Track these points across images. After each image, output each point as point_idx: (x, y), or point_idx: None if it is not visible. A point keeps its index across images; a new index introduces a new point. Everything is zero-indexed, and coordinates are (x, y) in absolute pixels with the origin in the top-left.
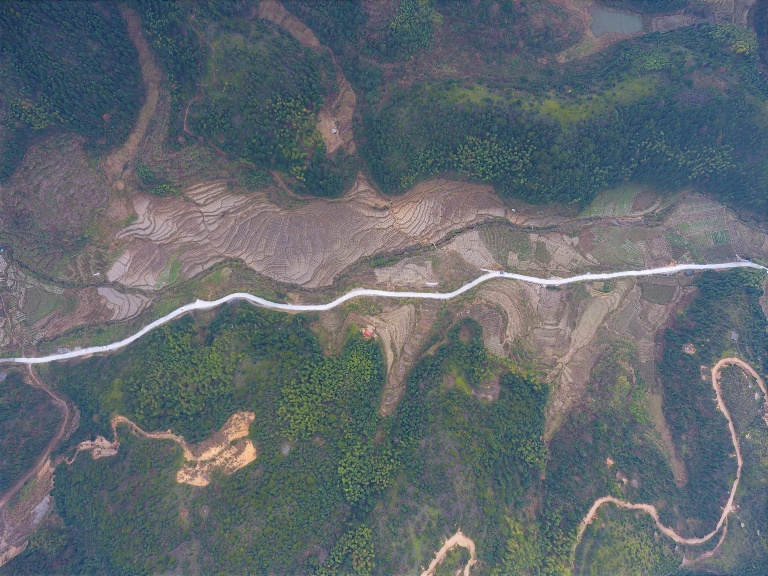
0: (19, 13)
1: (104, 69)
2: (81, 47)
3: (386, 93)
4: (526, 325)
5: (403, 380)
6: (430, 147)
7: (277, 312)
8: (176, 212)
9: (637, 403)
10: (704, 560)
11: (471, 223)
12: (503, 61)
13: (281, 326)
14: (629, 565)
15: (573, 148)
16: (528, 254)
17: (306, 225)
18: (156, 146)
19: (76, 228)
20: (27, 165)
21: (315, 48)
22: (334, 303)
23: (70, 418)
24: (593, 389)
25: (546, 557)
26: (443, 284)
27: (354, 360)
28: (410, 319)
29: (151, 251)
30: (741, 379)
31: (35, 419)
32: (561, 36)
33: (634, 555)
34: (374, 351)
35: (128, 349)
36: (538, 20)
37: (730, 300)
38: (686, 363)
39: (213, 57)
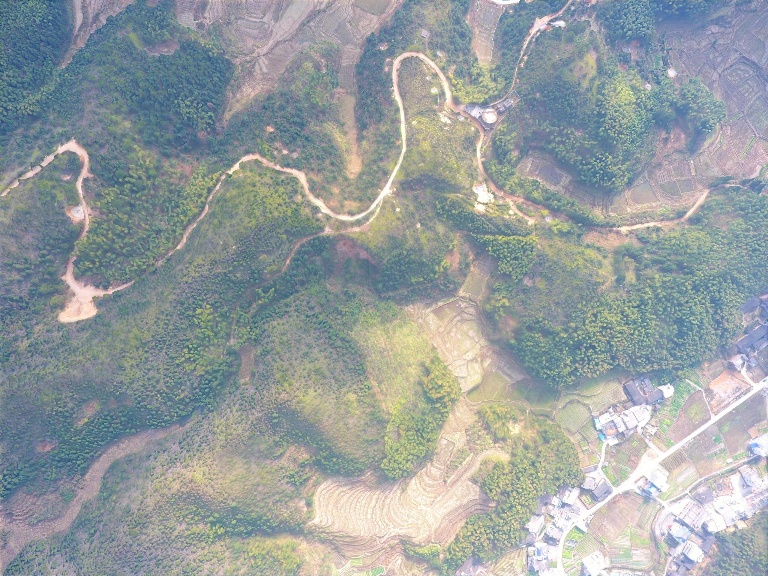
0: None
1: None
2: None
3: None
4: (228, 12)
5: None
6: None
7: None
8: None
9: (317, 88)
10: (349, 233)
11: None
12: None
13: None
14: (249, 203)
15: None
16: None
17: None
18: None
19: None
20: None
21: None
22: None
23: None
24: (282, 77)
25: (180, 200)
26: None
27: (29, 3)
28: None
29: None
30: (418, 69)
31: None
32: None
33: (259, 198)
34: None
35: None
36: None
37: (431, 3)
38: (376, 58)
39: None
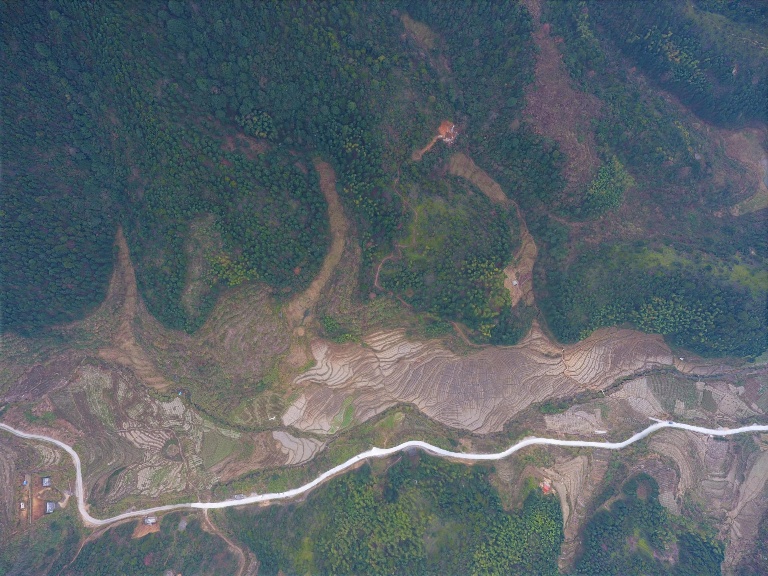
0: (235, 182)
1: (302, 227)
2: (284, 208)
3: (572, 250)
4: (696, 478)
5: (578, 534)
6: (612, 303)
7: (458, 466)
8: (353, 358)
9: None
10: None
11: (639, 370)
12: (682, 216)
13: (462, 481)
14: None
15: (760, 314)
16: (695, 403)
17: (478, 371)
18: (344, 298)
19: (257, 375)
20: (216, 315)
21: (503, 203)
22: (507, 452)
23: (246, 566)
24: (764, 546)
25: None
26: (612, 433)
27: (538, 520)
28: (583, 471)
29: (326, 395)
30: None
31: (217, 571)
32: (739, 192)
33: None
34: (557, 511)
35: (312, 503)
36: (720, 178)
37: None
38: None
39: (415, 221)
